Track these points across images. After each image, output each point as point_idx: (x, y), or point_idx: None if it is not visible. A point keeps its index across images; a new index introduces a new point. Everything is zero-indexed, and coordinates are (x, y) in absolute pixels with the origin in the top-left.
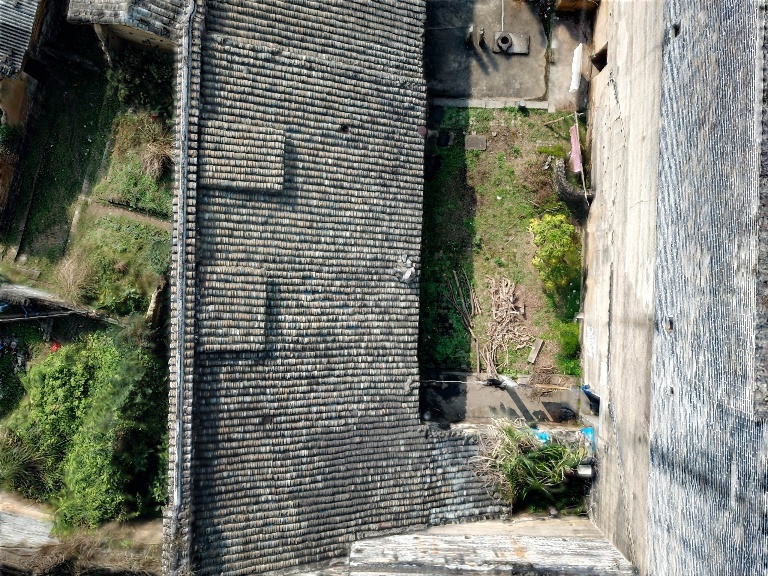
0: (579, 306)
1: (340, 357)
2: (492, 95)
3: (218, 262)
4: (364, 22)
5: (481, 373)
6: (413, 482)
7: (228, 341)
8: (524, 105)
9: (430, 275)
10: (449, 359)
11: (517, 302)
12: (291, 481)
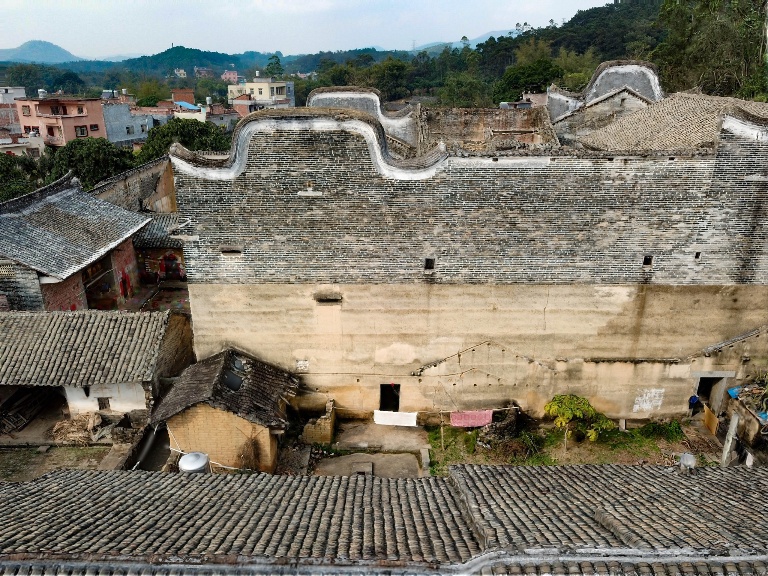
0: (613, 428)
1: None
2: None
3: None
4: None
5: None
6: None
7: None
8: None
9: None
10: None
11: None
12: None
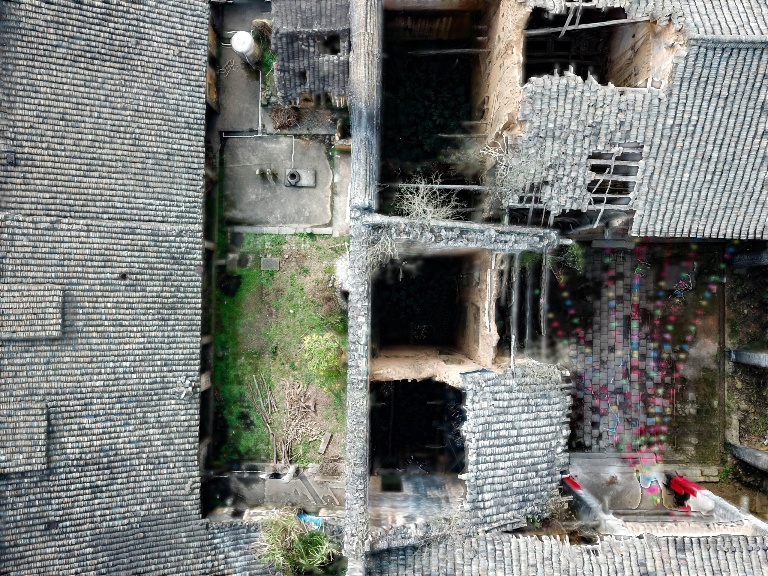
0: None
1: (123, 467)
2: (285, 222)
3: (3, 399)
4: (143, 183)
5: (277, 464)
6: (195, 568)
7: (11, 465)
8: (310, 232)
9: (234, 379)
10: (251, 451)
11: (308, 401)
12: (76, 575)
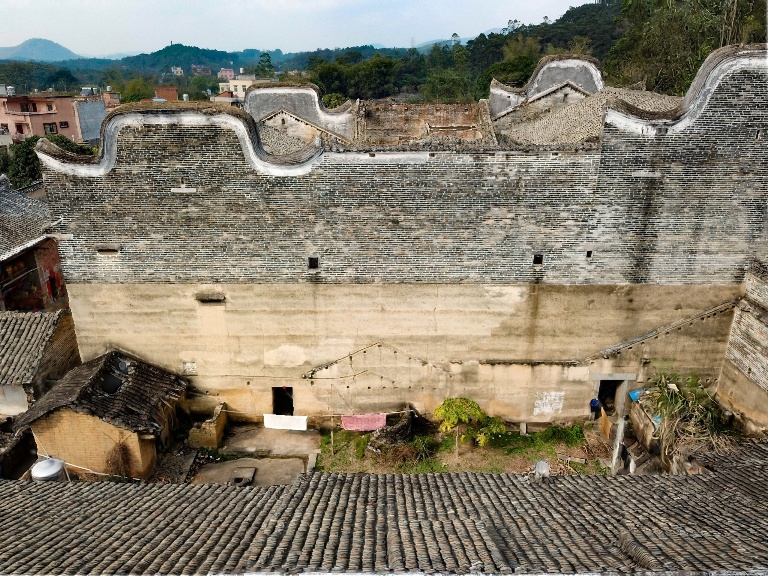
0: (514, 432)
1: None
2: None
3: None
4: None
5: None
6: None
7: None
8: None
9: None
10: None
11: None
12: None
